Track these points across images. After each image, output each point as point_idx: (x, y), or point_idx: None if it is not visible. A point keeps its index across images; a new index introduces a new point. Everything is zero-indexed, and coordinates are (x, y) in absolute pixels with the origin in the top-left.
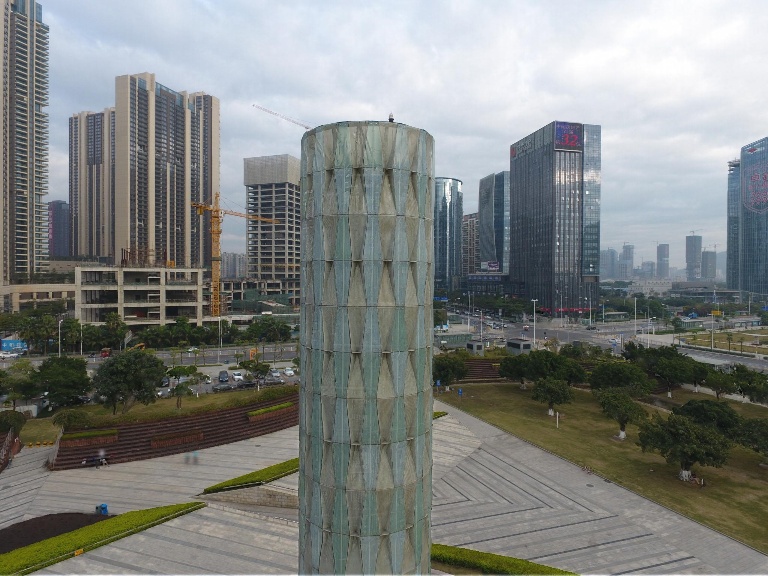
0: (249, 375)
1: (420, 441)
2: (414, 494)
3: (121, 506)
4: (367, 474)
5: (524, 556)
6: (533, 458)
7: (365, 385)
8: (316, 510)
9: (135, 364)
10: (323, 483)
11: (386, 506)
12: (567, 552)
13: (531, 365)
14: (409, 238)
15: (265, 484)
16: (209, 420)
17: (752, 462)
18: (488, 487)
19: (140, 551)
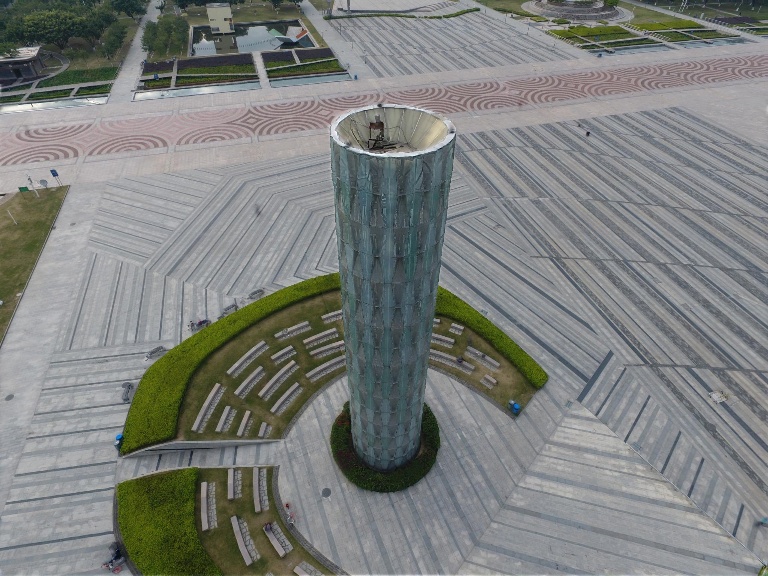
0: None
1: None
2: None
3: None
4: None
5: None
6: None
7: None
8: None
9: None
10: None
11: None
12: None
13: None
14: None
15: None
16: None
17: None
18: None
19: None
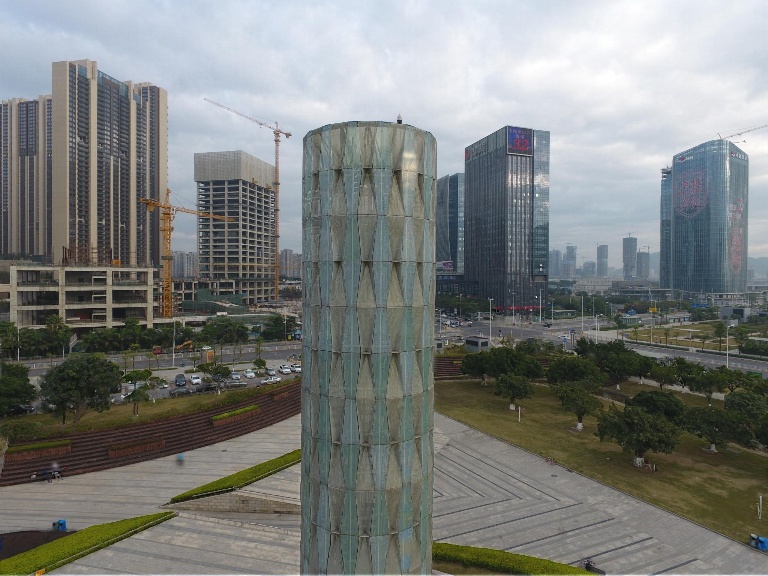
0: (208, 378)
1: (425, 439)
2: (420, 492)
3: (80, 521)
4: (376, 474)
5: (500, 547)
6: (499, 452)
7: (375, 385)
8: (323, 513)
9: (88, 369)
10: (331, 485)
11: (395, 505)
12: (539, 540)
13: (493, 362)
14: (416, 239)
15: (237, 490)
16: (171, 426)
17: (695, 447)
18: (459, 482)
19: (109, 567)
